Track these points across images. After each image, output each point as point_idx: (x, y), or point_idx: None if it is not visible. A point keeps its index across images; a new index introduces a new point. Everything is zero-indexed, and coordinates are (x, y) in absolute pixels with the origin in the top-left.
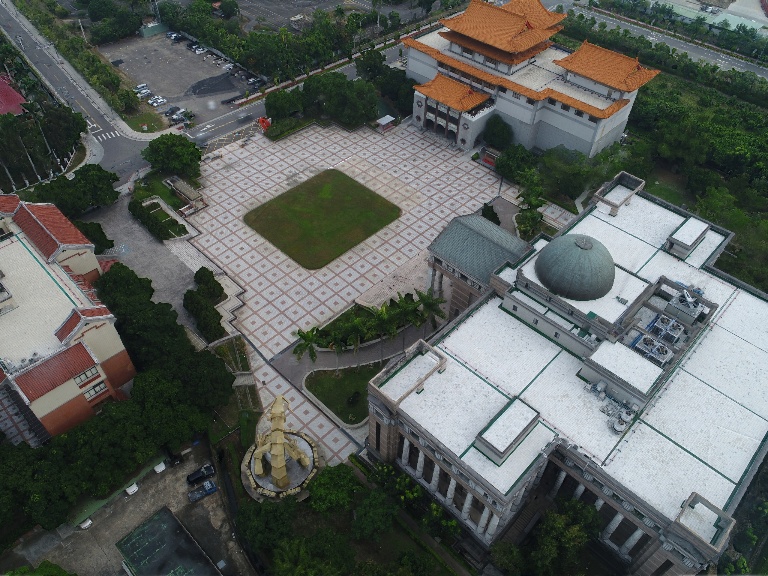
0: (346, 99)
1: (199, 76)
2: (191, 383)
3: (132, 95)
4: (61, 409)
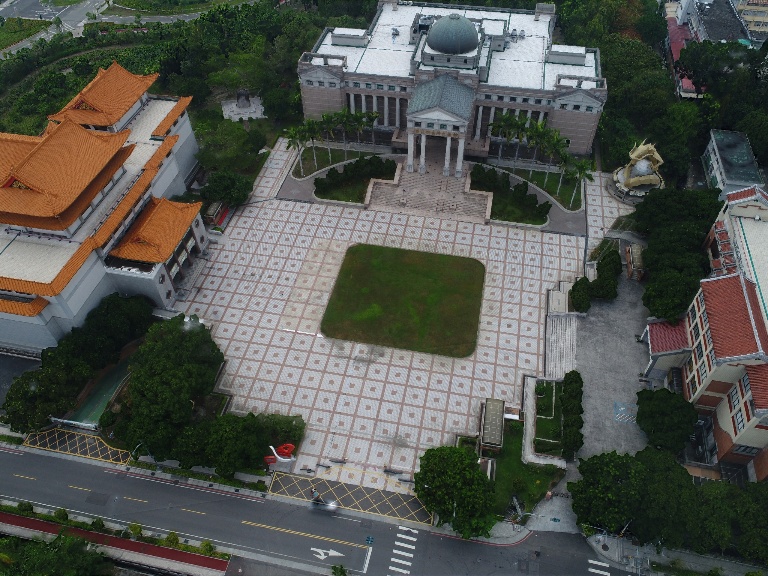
0: (194, 351)
1: None
2: None
3: None
4: None
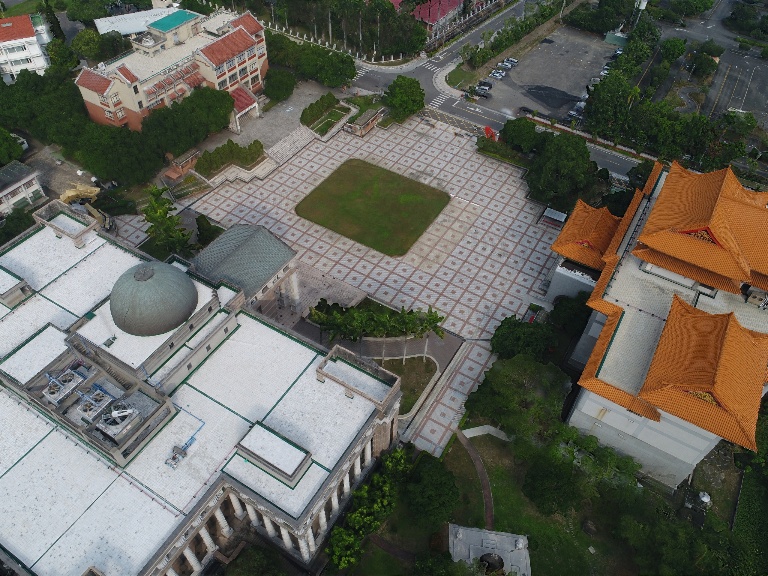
0: None
1: (560, 85)
2: None
3: (477, 54)
4: (93, 106)
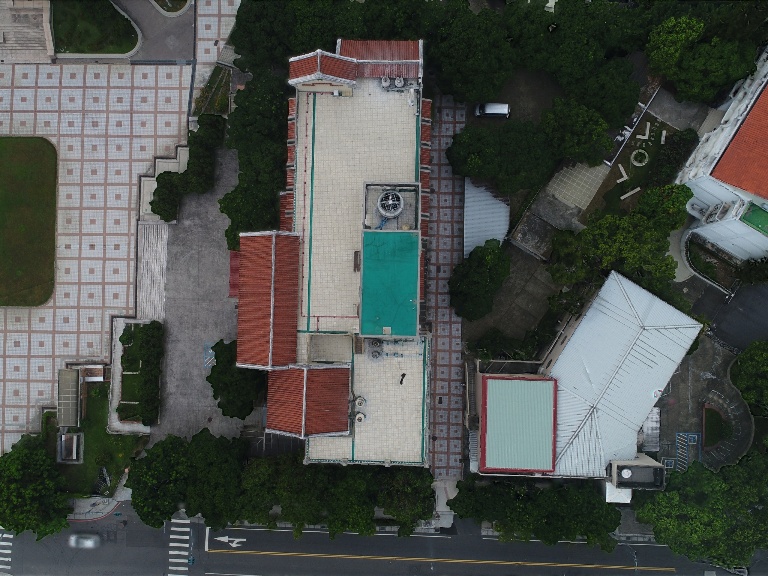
0: None
1: None
2: (277, 3)
3: None
4: None
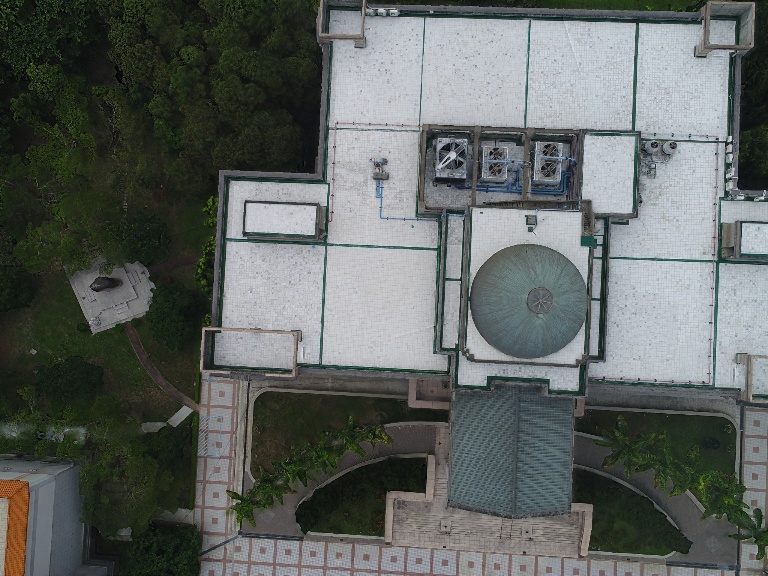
0: None
1: None
2: None
3: None
4: None
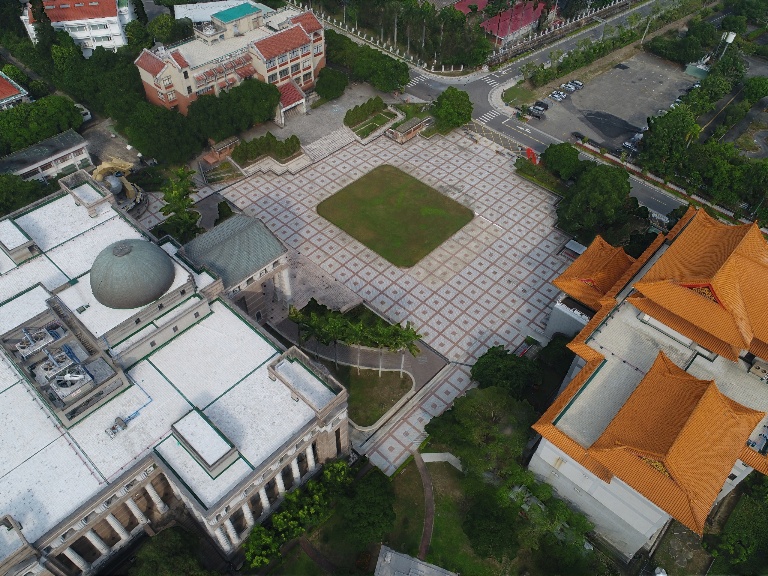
0: None
1: (623, 113)
2: None
3: (539, 73)
4: None
